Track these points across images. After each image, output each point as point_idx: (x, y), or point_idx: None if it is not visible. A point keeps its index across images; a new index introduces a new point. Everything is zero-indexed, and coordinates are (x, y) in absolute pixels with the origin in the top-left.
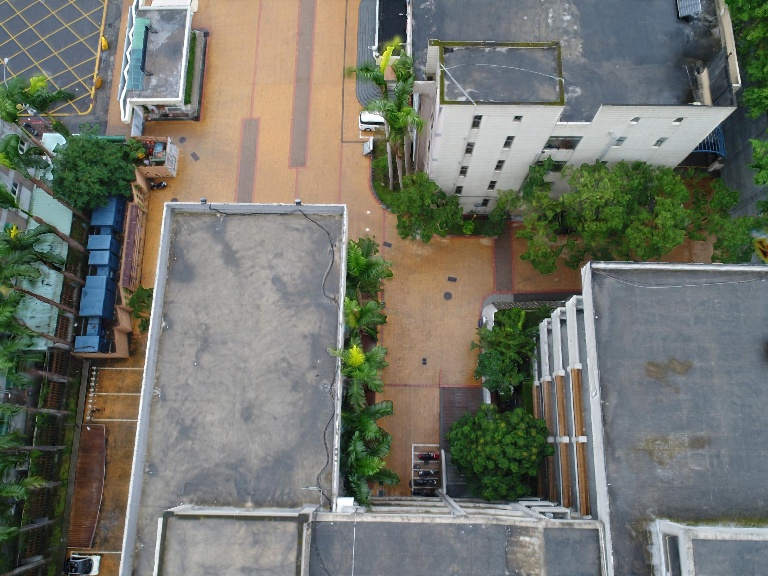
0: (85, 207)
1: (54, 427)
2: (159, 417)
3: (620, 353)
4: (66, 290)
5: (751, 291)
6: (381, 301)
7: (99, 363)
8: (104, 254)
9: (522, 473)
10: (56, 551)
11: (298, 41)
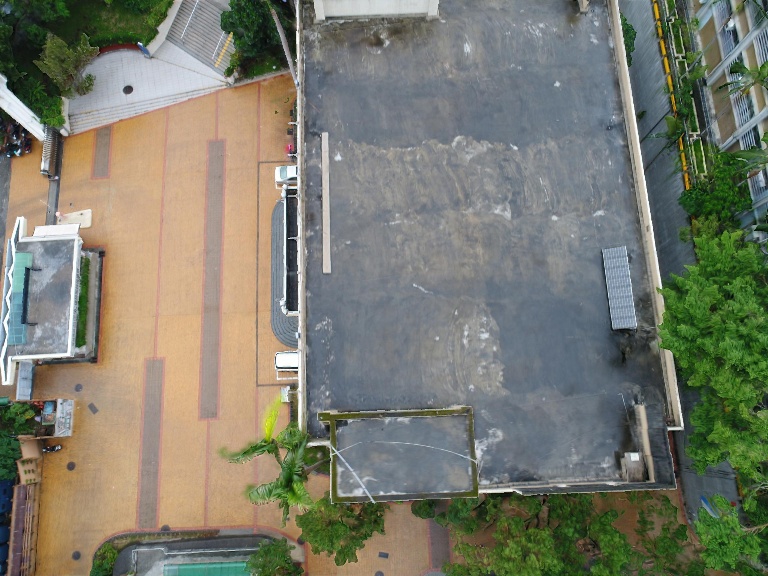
0: None
1: None
2: None
3: None
4: None
5: None
6: None
7: None
8: None
9: None
10: None
11: (205, 261)
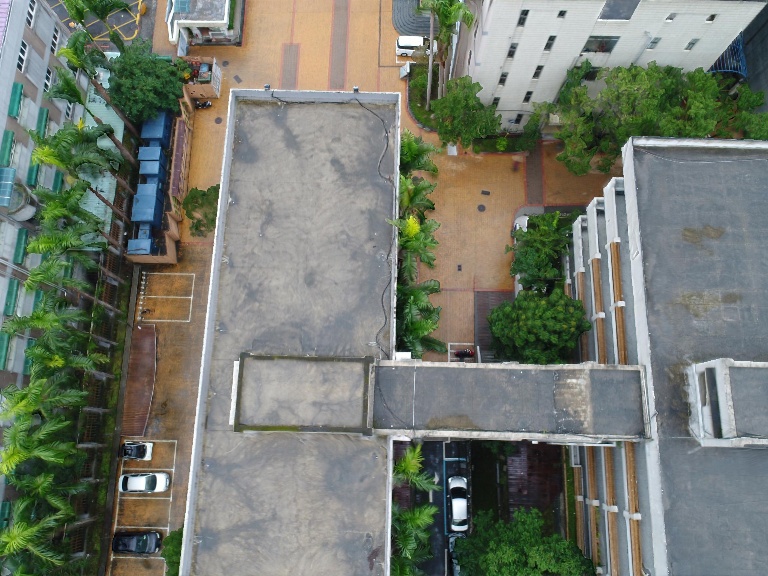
0: (138, 117)
1: (107, 326)
2: (228, 282)
3: (659, 220)
4: (117, 199)
5: None
6: None
7: (148, 269)
8: (154, 164)
9: (561, 346)
10: (110, 439)
11: None
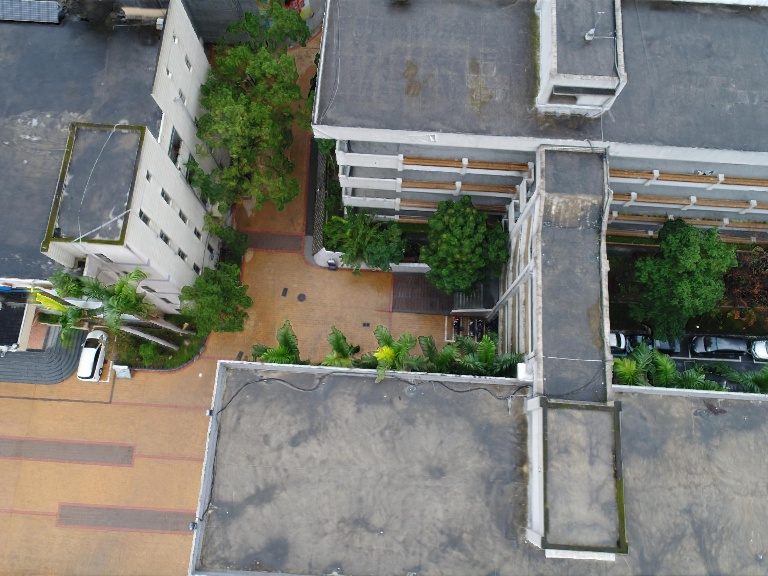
0: None
1: None
2: (438, 573)
3: (397, 114)
4: None
5: (347, 8)
6: None
7: None
8: None
9: None
10: None
11: None
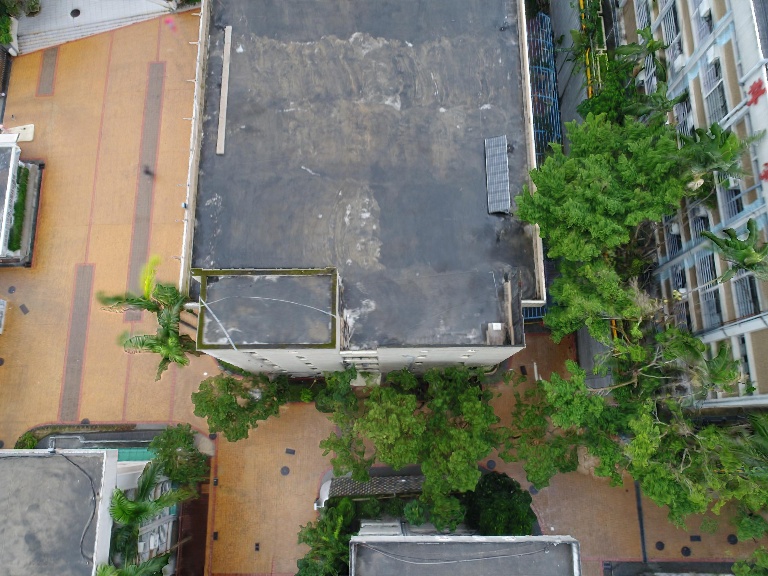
0: None
1: None
2: None
3: None
4: None
5: (533, 565)
6: (214, 477)
7: None
8: None
9: None
10: None
11: (139, 174)
